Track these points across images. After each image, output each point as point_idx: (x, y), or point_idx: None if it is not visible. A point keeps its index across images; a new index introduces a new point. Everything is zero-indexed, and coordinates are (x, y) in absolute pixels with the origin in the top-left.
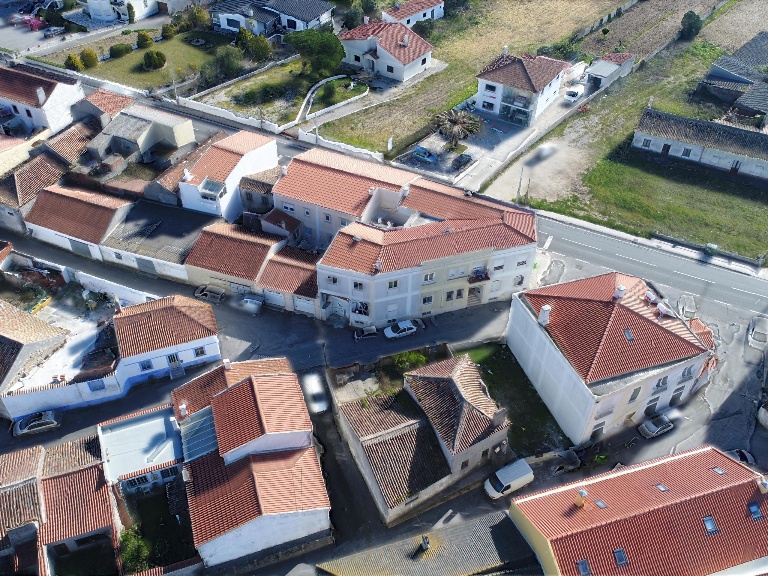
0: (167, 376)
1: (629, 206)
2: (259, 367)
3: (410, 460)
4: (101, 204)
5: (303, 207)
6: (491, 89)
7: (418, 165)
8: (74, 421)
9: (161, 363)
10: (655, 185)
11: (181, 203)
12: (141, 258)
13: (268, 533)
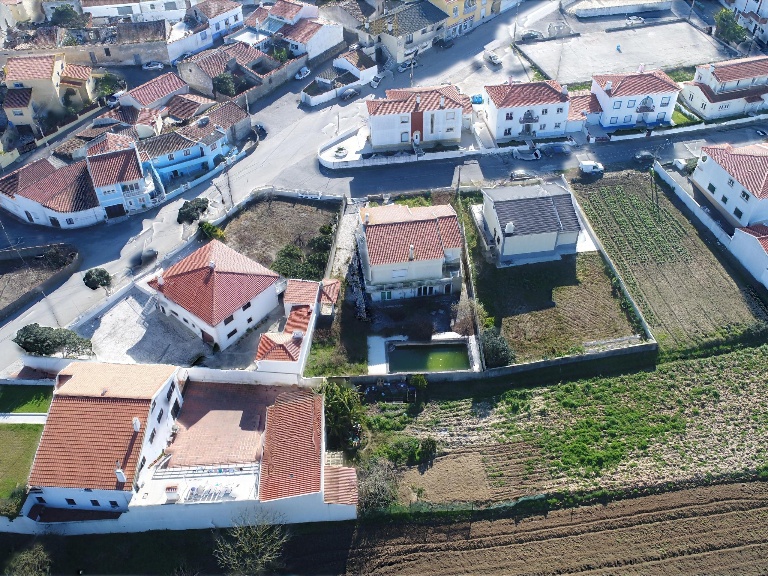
0: (226, 34)
1: None
2: None
3: (360, 9)
4: None
5: None
6: None
7: None
8: None
9: (223, 25)
10: None
11: None
12: (168, 2)
13: (326, 39)
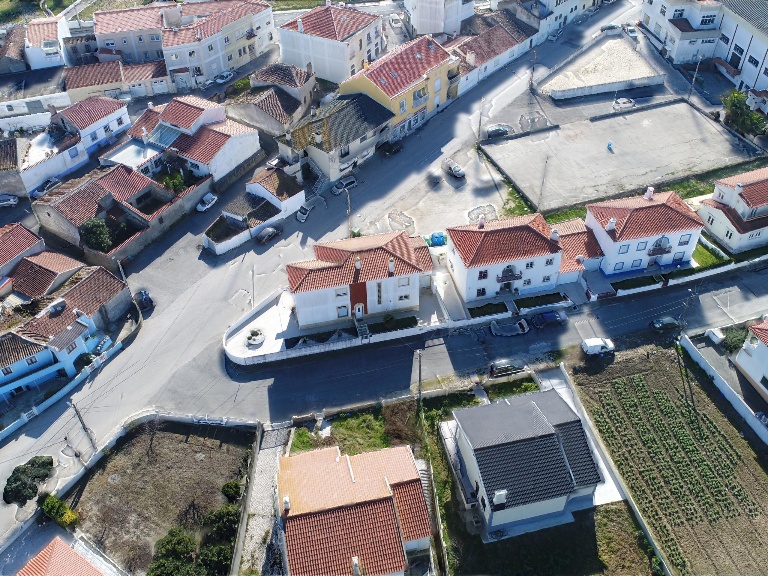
0: (107, 144)
1: None
2: None
3: (280, 104)
4: None
5: (121, 38)
6: None
7: None
8: None
9: (101, 134)
10: None
11: (29, 67)
12: (30, 101)
13: (236, 152)
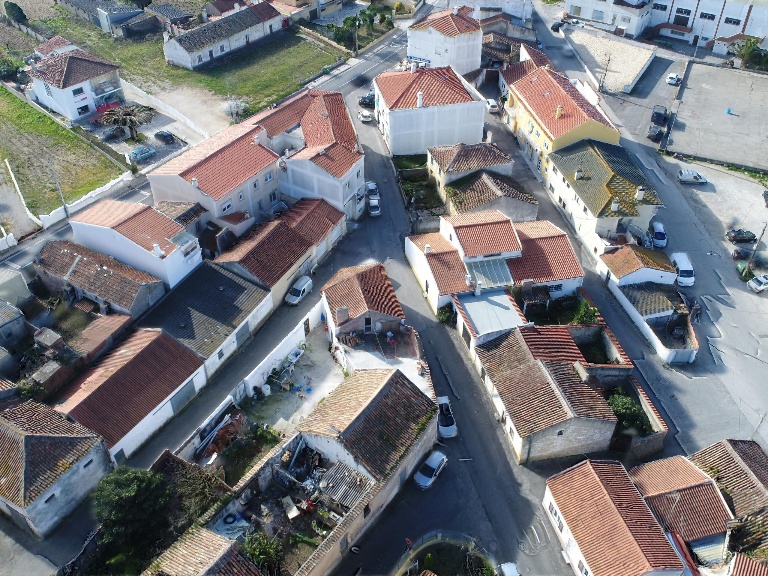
0: None
1: (267, 85)
2: (422, 244)
3: None
4: (140, 349)
5: (238, 193)
6: (79, 92)
7: (152, 161)
8: (439, 393)
9: None
10: (246, 72)
11: (168, 287)
12: None
13: None
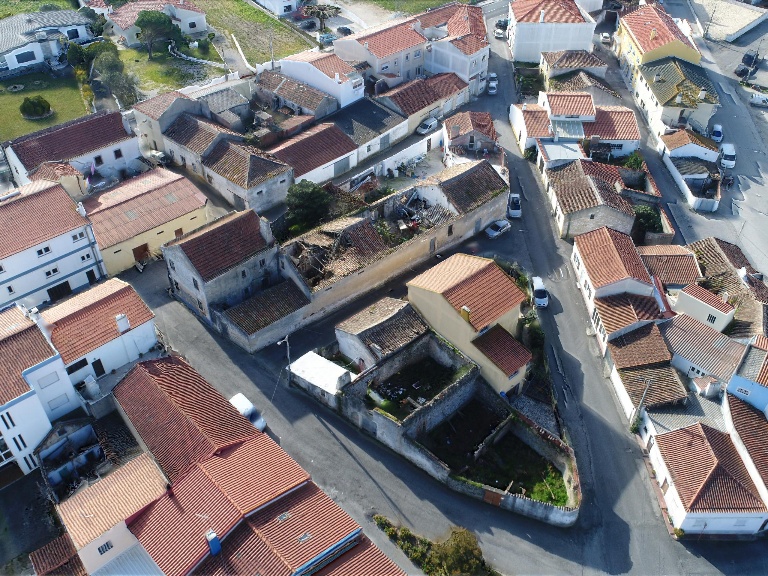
0: None
1: (425, 7)
2: None
3: None
4: None
5: (394, 59)
6: None
7: None
8: None
9: None
10: None
11: (339, 106)
12: None
13: None
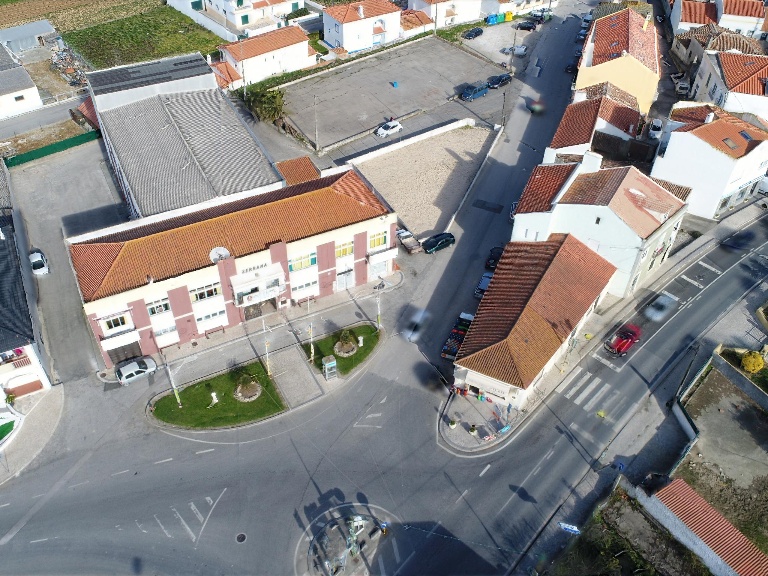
0: None
1: None
2: None
3: None
4: None
5: None
6: None
7: None
8: None
9: None
10: None
11: None
12: None
13: None
